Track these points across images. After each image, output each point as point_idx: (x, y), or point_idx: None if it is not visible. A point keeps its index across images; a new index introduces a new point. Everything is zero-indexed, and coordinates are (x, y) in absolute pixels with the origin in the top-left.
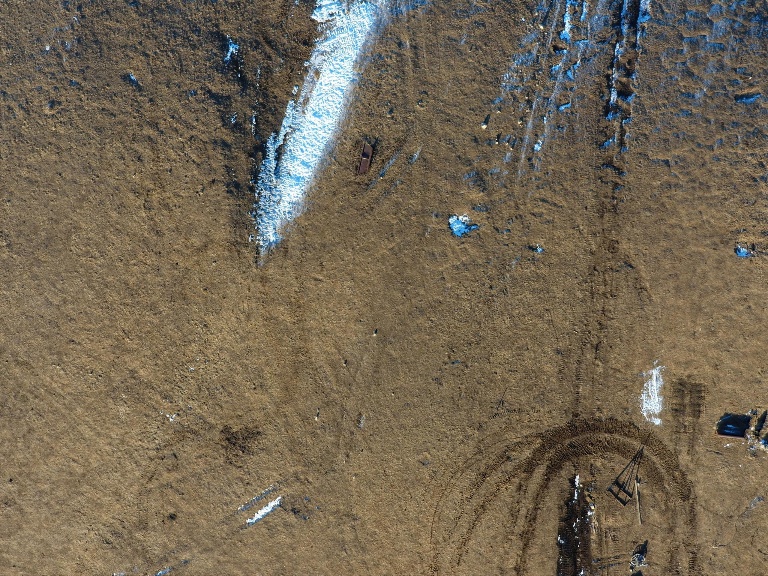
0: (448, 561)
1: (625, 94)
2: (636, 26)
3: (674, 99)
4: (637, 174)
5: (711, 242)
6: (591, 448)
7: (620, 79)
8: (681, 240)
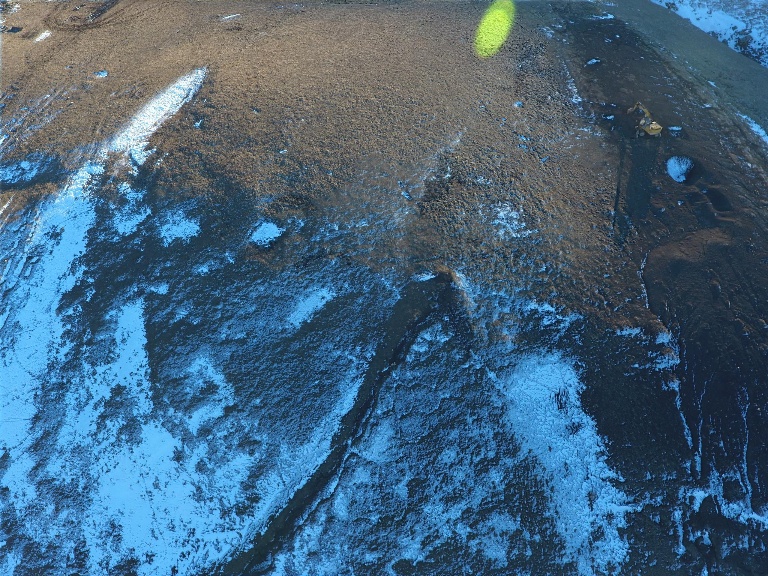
0: (157, 7)
1: None
2: None
3: None
4: (4, 86)
5: None
6: None
7: None
8: None
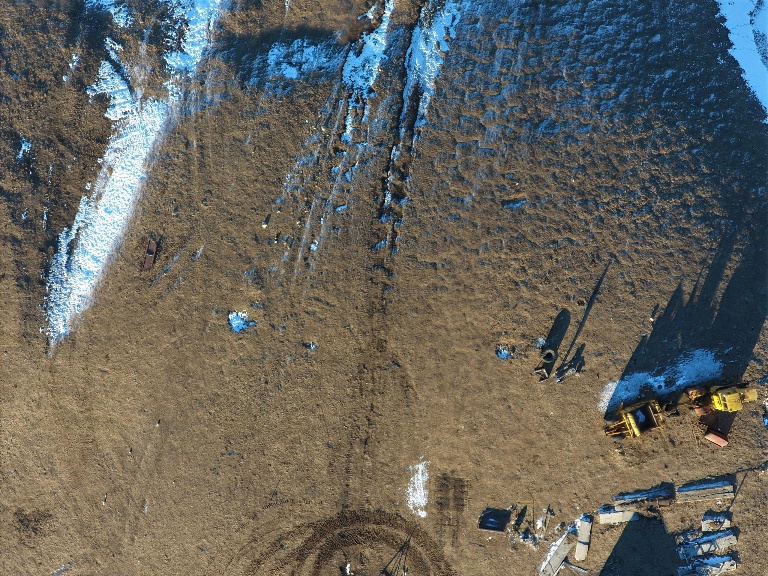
0: None
1: (398, 197)
2: (413, 130)
3: (444, 203)
4: (405, 276)
5: (474, 343)
6: (361, 538)
7: (394, 182)
8: (445, 341)
